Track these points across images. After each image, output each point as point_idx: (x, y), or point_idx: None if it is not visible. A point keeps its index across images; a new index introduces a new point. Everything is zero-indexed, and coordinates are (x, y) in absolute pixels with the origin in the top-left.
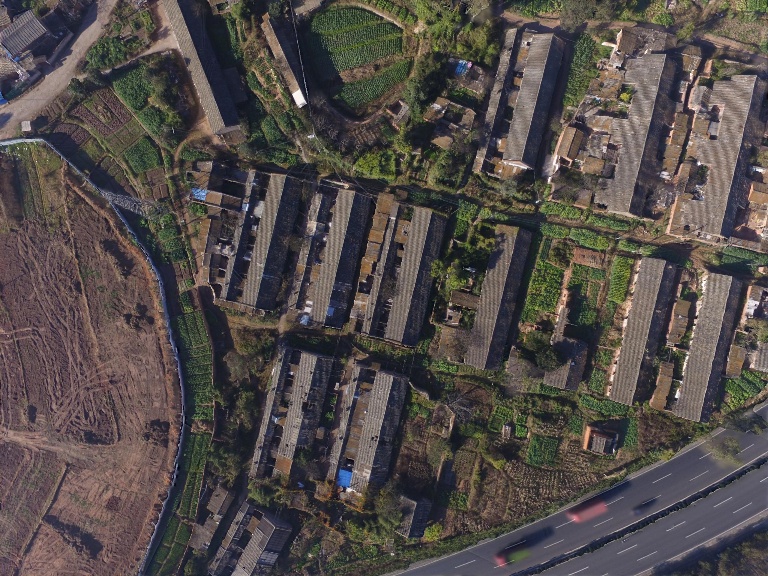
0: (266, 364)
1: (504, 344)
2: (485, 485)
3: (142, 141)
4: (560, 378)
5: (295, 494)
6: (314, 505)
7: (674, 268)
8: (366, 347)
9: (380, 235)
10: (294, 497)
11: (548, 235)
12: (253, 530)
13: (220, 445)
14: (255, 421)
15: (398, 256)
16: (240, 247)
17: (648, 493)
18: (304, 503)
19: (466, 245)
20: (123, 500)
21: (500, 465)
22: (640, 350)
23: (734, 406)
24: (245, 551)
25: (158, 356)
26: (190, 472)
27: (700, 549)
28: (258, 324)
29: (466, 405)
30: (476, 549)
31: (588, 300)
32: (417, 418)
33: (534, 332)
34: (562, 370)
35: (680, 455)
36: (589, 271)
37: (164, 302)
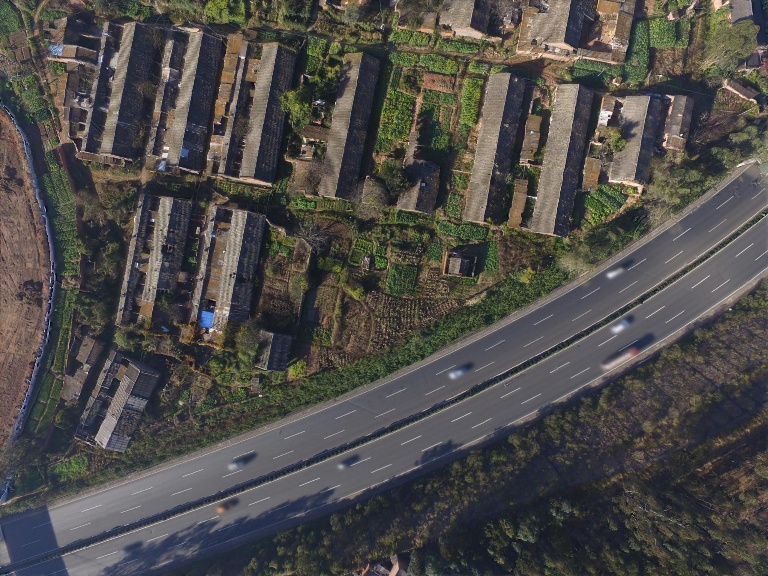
0: (130, 215)
1: (357, 173)
2: (347, 319)
3: (3, 5)
4: (411, 200)
5: (159, 338)
6: (179, 349)
7: (522, 83)
8: (226, 191)
9: (231, 75)
10: (159, 342)
11: (398, 64)
12: (121, 378)
13: (85, 294)
14: (121, 272)
15: (251, 96)
16: (97, 99)
17: (530, 335)
18: (169, 347)
19: (316, 78)
20: (1, 362)
21: (358, 295)
22: (490, 165)
23: (595, 222)
24: (114, 399)
25: (29, 217)
26: (62, 328)
27: (586, 389)
28: (121, 177)
29: (320, 235)
30: (356, 399)
31: (441, 125)
32: (278, 257)
33: (388, 161)
34: (413, 192)
35: (561, 296)
36: (440, 96)
37: (31, 162)
